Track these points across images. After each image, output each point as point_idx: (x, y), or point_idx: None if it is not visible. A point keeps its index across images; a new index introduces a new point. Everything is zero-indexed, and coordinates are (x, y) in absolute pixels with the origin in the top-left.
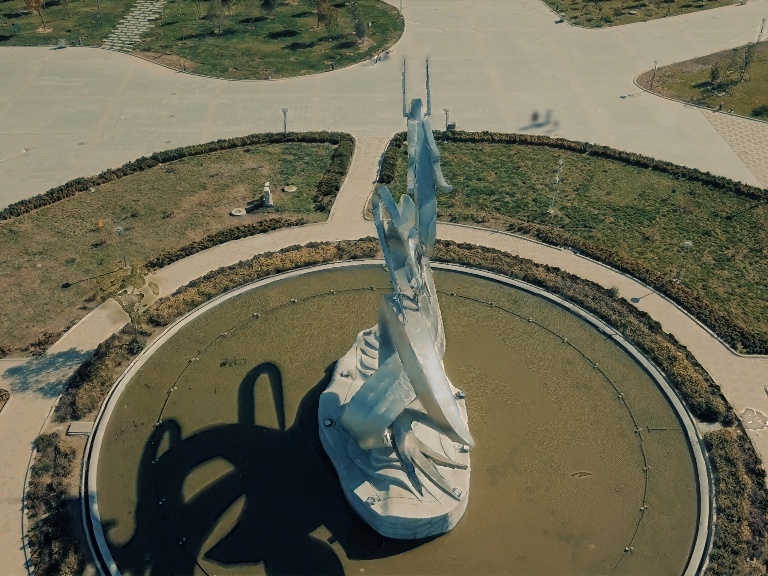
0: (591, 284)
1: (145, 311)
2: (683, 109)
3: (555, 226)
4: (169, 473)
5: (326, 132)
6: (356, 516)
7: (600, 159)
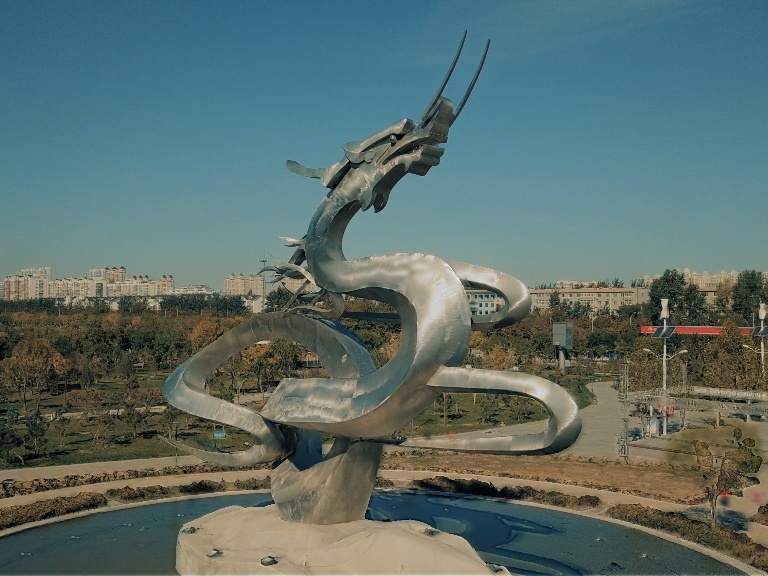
0: None
1: None
2: None
3: None
4: None
5: None
6: None
7: None
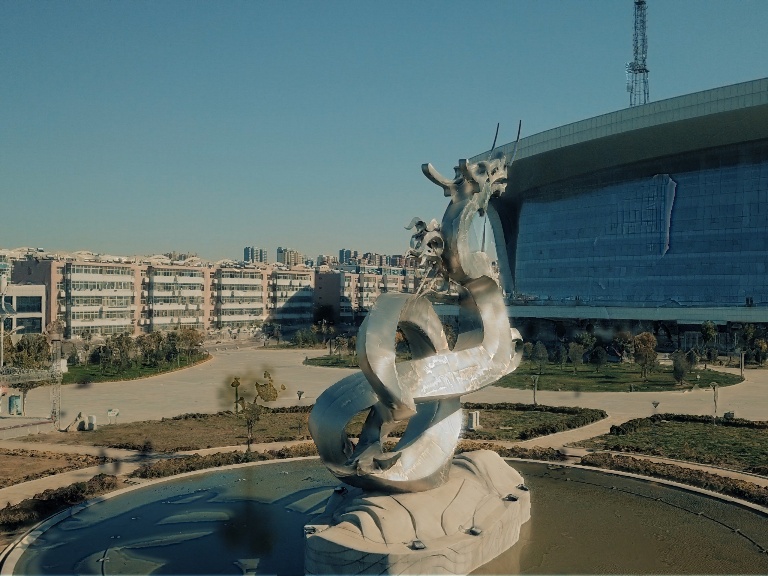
0: None
1: None
2: None
3: None
4: (168, 511)
5: (579, 408)
6: None
7: None
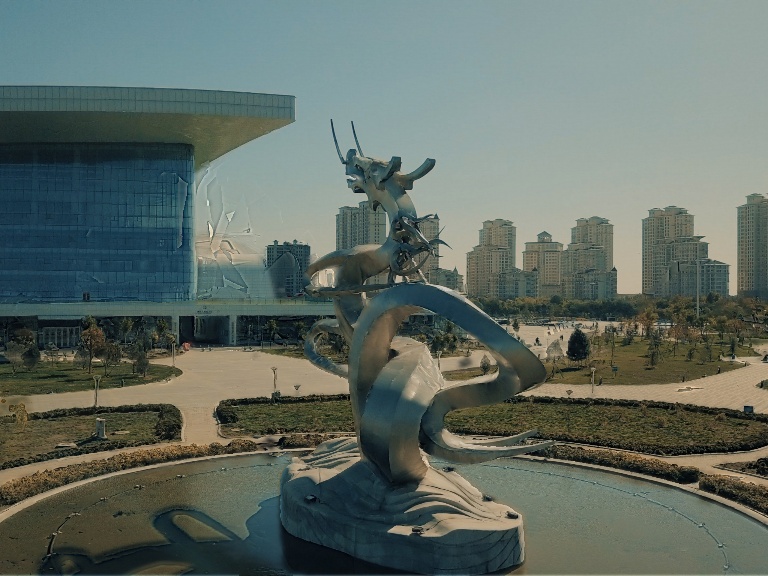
0: None
1: None
2: None
3: None
4: None
5: (142, 404)
6: (394, 575)
7: None
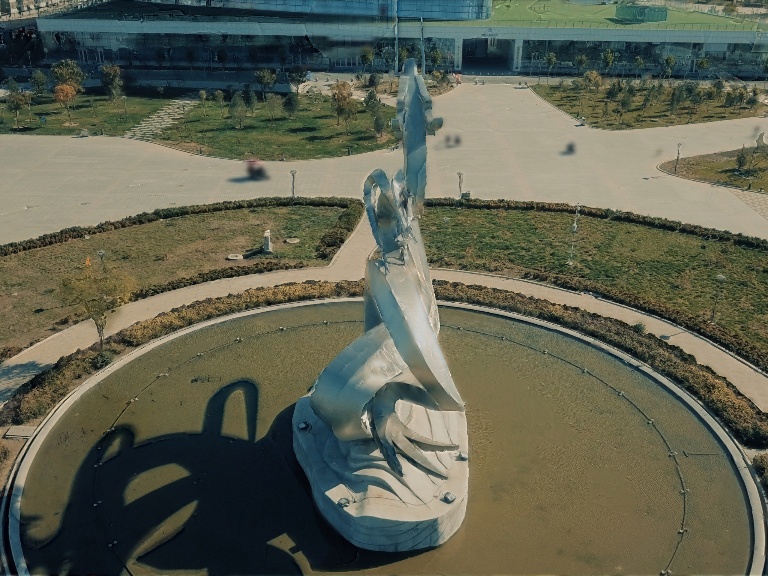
0: (614, 321)
1: (118, 333)
2: (710, 188)
3: (574, 276)
4: (112, 477)
5: (335, 197)
6: (327, 527)
7: (623, 223)
